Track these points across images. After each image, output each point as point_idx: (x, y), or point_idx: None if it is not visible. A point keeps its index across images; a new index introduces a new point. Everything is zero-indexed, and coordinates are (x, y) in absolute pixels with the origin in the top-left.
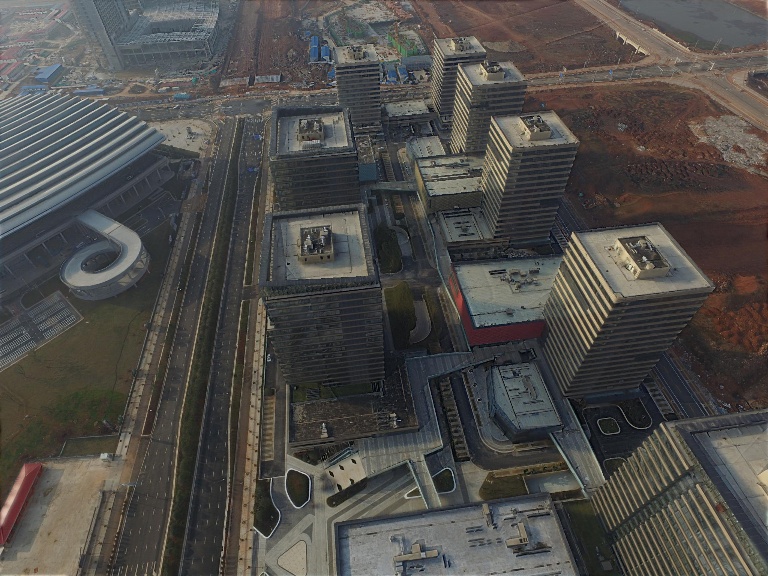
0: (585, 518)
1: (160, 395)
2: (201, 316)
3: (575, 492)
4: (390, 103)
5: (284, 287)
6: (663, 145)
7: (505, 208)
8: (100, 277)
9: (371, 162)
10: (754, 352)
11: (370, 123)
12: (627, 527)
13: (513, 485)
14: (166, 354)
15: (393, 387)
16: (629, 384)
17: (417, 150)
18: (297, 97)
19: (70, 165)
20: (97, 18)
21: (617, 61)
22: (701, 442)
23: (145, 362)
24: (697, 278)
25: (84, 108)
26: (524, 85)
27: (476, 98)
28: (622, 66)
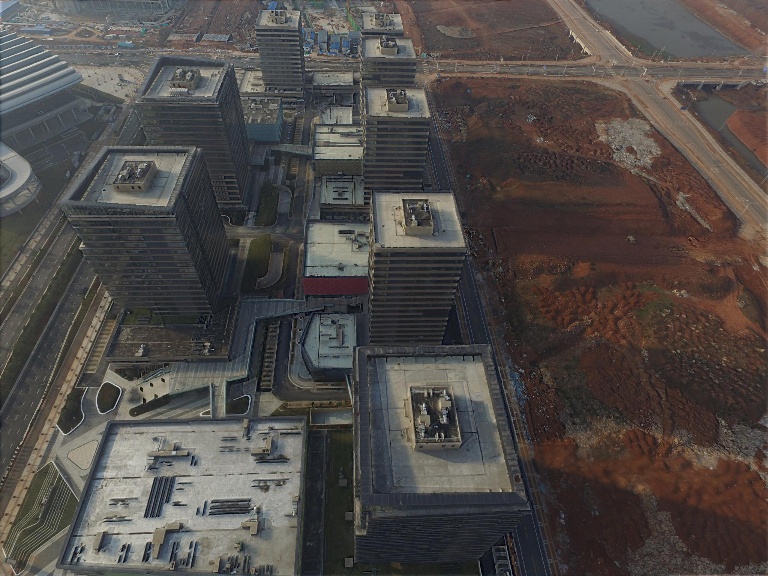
0: (343, 444)
1: (11, 308)
2: (72, 245)
3: (351, 426)
4: (320, 72)
5: (84, 207)
6: (562, 139)
7: (370, 175)
8: None
9: (272, 123)
10: (563, 328)
11: (292, 89)
12: None
13: None
14: (29, 274)
15: (218, 321)
16: (430, 341)
17: (327, 118)
18: (237, 58)
19: None
20: None
21: (558, 57)
22: (377, 365)
23: (8, 279)
24: (458, 240)
25: (8, 42)
26: (413, 62)
27: (367, 70)
28: (561, 63)
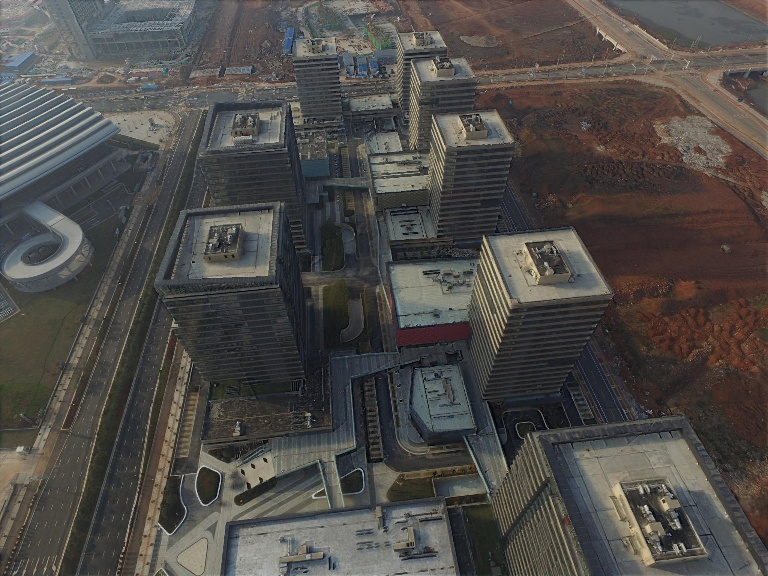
0: (483, 523)
1: (85, 389)
2: (136, 310)
3: (482, 496)
4: (355, 97)
5: (180, 286)
6: (624, 145)
7: (445, 207)
8: (38, 269)
9: (323, 158)
10: (683, 358)
11: (332, 117)
12: (514, 534)
13: (421, 487)
14: (97, 348)
15: (313, 386)
16: (548, 388)
17: (375, 146)
18: (265, 89)
19: (18, 156)
20: (67, 6)
21: (592, 58)
22: (563, 453)
23: (75, 356)
24: (599, 285)
25: (39, 98)
26: (473, 82)
27: (425, 95)
28: (597, 63)
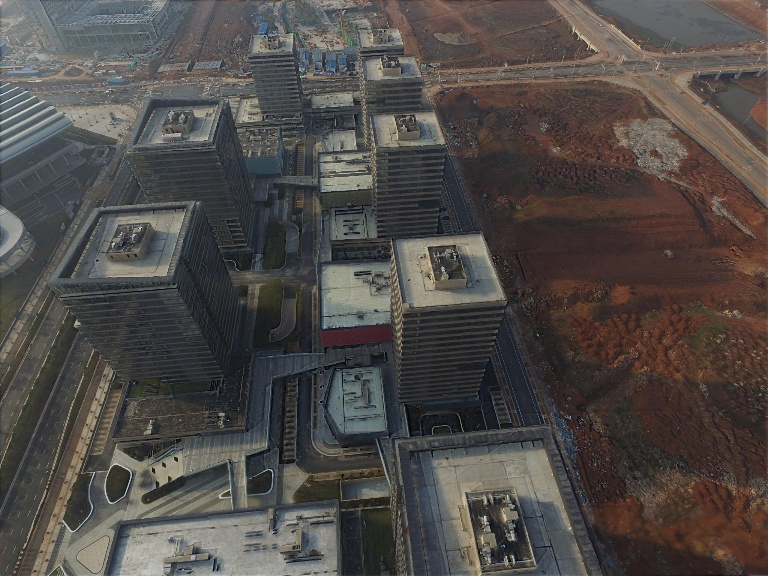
0: (381, 526)
1: (9, 384)
2: None
3: (387, 499)
4: (318, 94)
5: (75, 285)
6: (580, 147)
7: (382, 208)
8: None
9: (273, 155)
10: (609, 364)
11: (291, 114)
12: None
13: (329, 489)
14: (26, 343)
15: (232, 386)
16: (465, 392)
17: (330, 144)
18: (231, 85)
19: None
20: None
21: (564, 57)
22: (422, 461)
23: (4, 351)
24: (495, 291)
25: None
26: (419, 82)
27: (371, 94)
28: (567, 63)
